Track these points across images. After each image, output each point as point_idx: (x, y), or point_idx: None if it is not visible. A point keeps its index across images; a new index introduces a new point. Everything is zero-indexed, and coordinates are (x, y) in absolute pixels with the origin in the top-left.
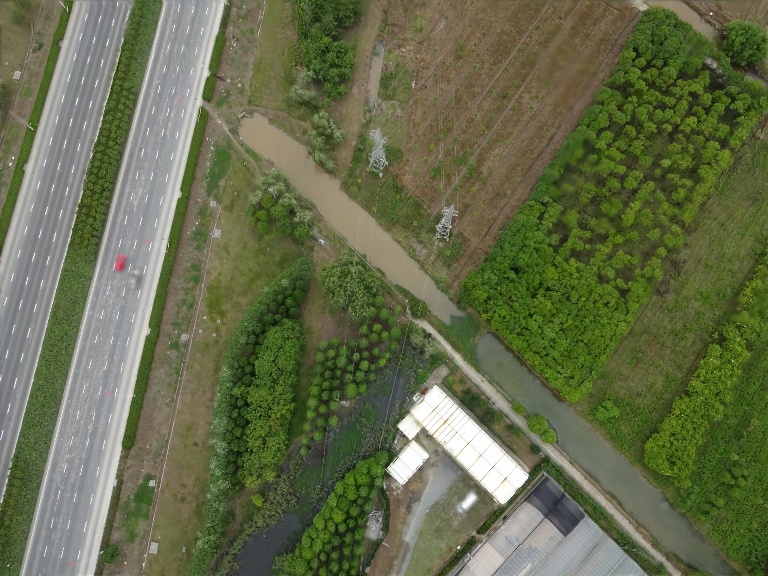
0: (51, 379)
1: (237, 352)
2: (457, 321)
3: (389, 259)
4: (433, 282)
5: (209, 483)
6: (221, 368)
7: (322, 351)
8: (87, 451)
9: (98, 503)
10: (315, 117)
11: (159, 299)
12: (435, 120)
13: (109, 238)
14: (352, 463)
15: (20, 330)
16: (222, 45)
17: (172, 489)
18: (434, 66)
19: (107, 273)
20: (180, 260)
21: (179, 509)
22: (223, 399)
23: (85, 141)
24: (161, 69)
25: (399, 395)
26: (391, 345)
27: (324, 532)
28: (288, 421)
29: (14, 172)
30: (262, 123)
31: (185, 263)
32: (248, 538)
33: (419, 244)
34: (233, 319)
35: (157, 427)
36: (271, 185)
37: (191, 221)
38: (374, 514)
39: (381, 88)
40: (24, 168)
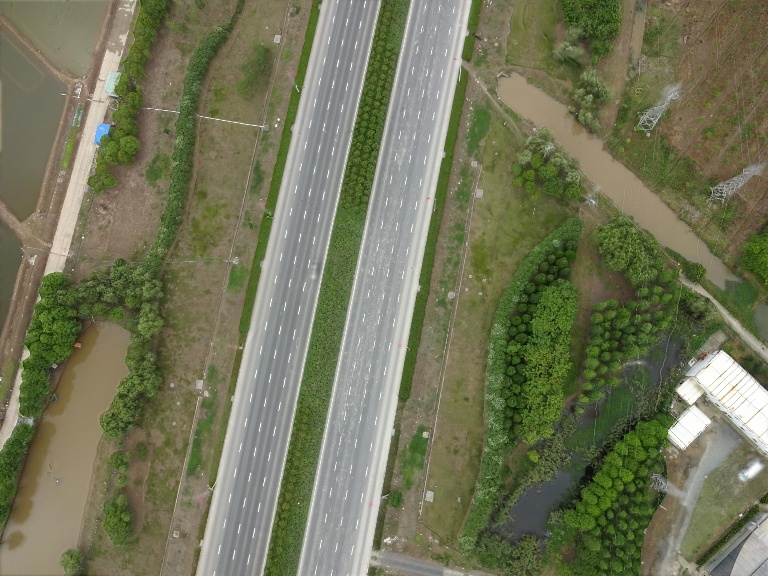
0: (329, 331)
1: (510, 311)
2: (733, 286)
3: (658, 221)
4: (705, 245)
5: (487, 437)
6: (494, 326)
7: (600, 312)
8: (365, 401)
9: (378, 450)
10: (590, 74)
11: (428, 257)
12: (711, 76)
13: (376, 197)
14: (629, 425)
15: (296, 284)
16: (479, 3)
17: (445, 441)
18: (710, 19)
19: (376, 231)
20: (445, 219)
21: (452, 461)
22: (498, 356)
23: (348, 102)
24: (418, 29)
25: (673, 359)
26: (673, 308)
27: (611, 491)
28: (564, 380)
29: (283, 133)
30: (520, 82)
31: (449, 222)
32: (523, 492)
33: (691, 206)
34: (499, 279)
35: (428, 381)
36: (542, 144)
37: (454, 181)
38: (656, 476)
39: (645, 44)
40: (291, 129)
